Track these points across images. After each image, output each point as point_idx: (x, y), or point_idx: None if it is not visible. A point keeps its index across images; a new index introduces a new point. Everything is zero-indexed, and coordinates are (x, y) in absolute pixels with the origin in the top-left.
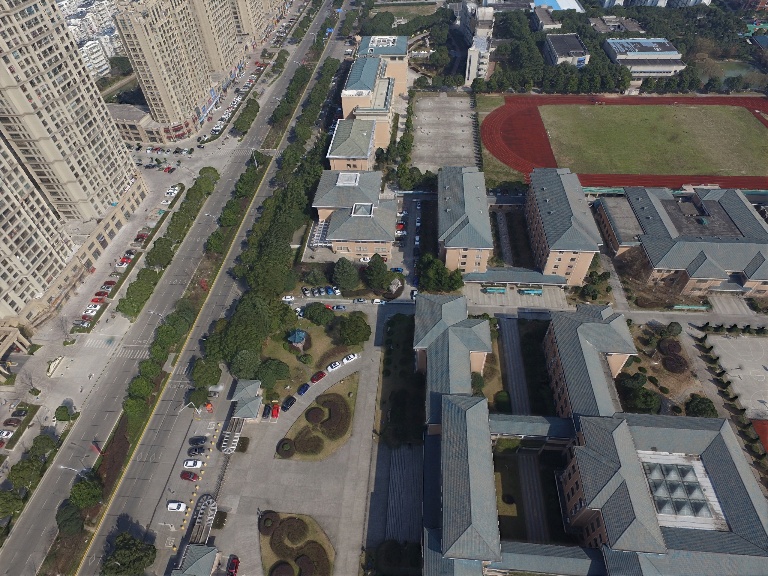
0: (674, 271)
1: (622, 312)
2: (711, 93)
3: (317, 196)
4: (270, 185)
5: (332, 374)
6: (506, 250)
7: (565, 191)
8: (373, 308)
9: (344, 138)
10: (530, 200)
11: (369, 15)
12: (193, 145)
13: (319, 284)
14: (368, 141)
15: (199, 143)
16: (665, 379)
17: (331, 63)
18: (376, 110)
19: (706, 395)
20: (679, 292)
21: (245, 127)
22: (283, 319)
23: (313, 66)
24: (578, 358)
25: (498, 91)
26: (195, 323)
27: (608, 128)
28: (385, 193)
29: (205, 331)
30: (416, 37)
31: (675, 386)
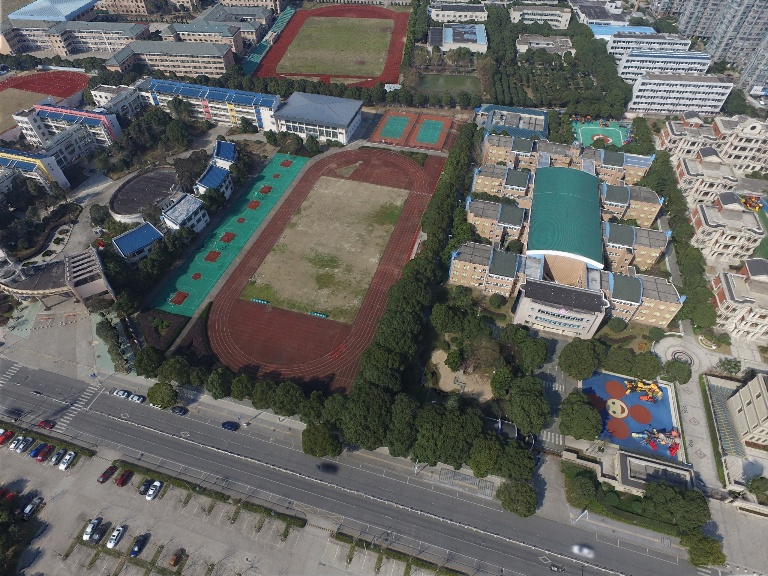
0: None
1: None
2: None
3: None
4: None
5: None
6: None
7: None
8: None
9: None
10: None
11: None
12: None
13: None
14: None
15: None
16: None
17: None
18: None
19: None
20: None
21: None
22: None
23: None
24: None
25: None
26: None
27: (355, 32)
28: None
29: None
30: None
31: None
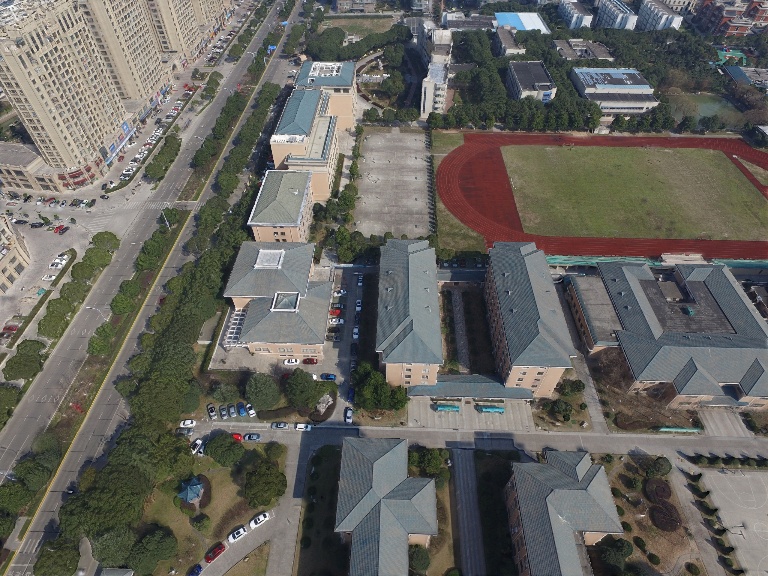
0: (659, 382)
1: (599, 436)
2: (685, 133)
3: (231, 281)
4: (183, 251)
5: (234, 546)
6: (462, 345)
7: (530, 281)
8: (295, 436)
9: (270, 200)
10: (490, 281)
11: (318, 28)
12: (96, 194)
13: (230, 400)
14: (300, 202)
15: (103, 192)
16: (654, 541)
17: (269, 90)
18: (312, 160)
19: (704, 565)
20: (664, 405)
21: (159, 173)
22: (173, 467)
23: (250, 91)
24: (548, 548)
25: (457, 127)
26: (61, 465)
27: (577, 176)
28: (321, 263)
29: (73, 478)
30: (369, 57)
31: (666, 552)
